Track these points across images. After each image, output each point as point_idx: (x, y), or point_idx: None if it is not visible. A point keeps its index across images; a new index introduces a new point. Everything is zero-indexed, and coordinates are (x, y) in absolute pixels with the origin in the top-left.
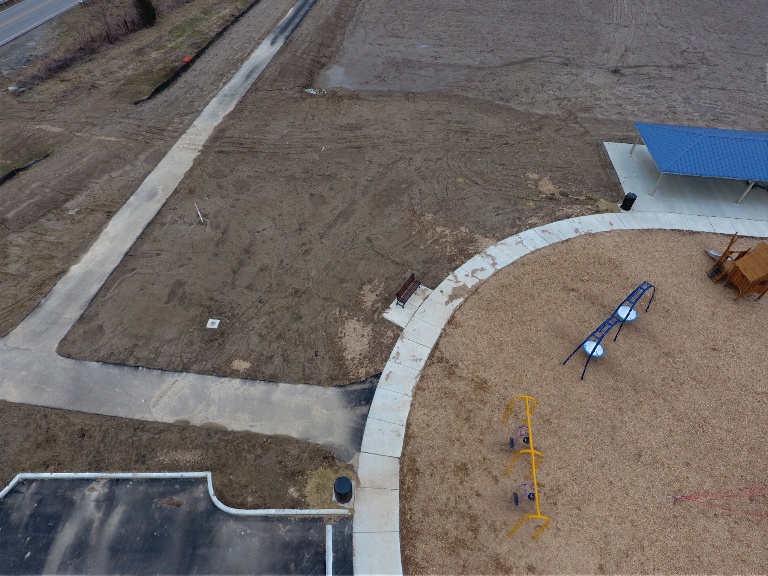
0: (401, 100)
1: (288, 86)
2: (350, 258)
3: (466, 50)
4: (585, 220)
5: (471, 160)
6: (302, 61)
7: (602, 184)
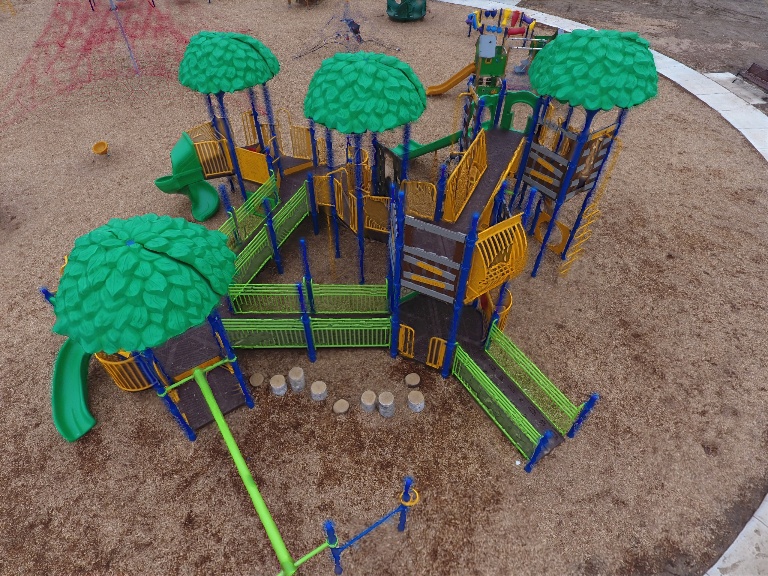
0: None
1: None
2: None
3: None
4: None
5: None
6: None
7: None
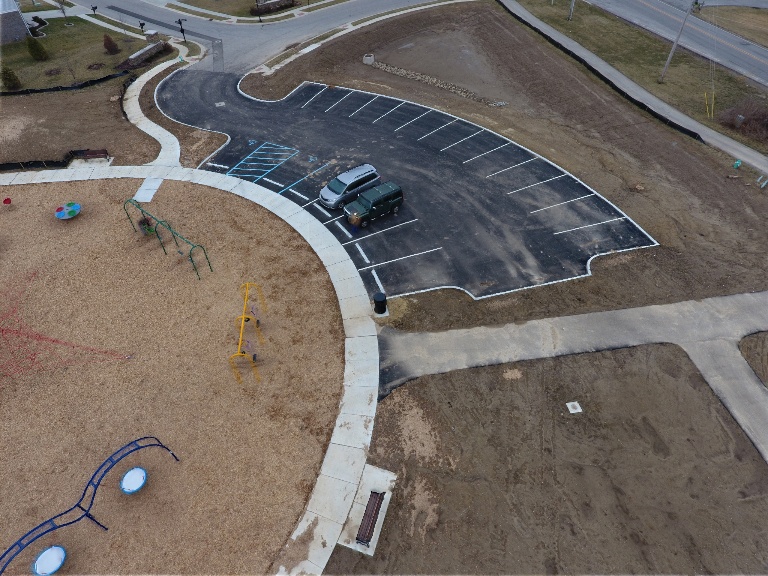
0: None
1: None
2: (480, 575)
3: None
4: None
5: None
6: None
7: None
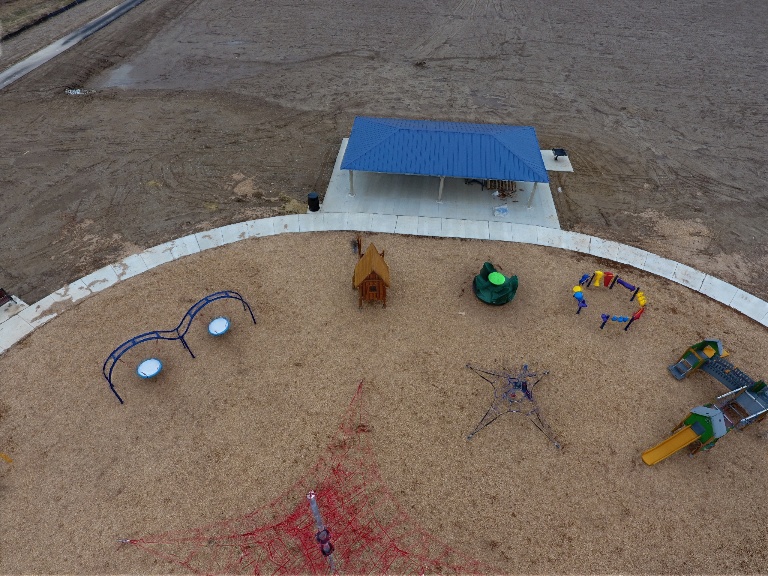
0: (154, 99)
1: (48, 87)
2: None
3: (276, 46)
4: (260, 223)
5: (181, 161)
6: (85, 61)
7: (309, 183)
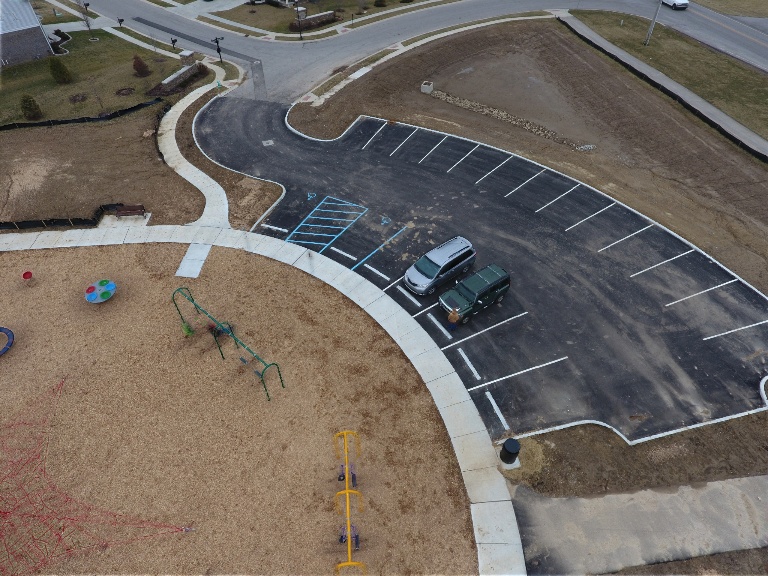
0: None
1: None
2: None
3: None
4: None
5: None
6: None
7: None
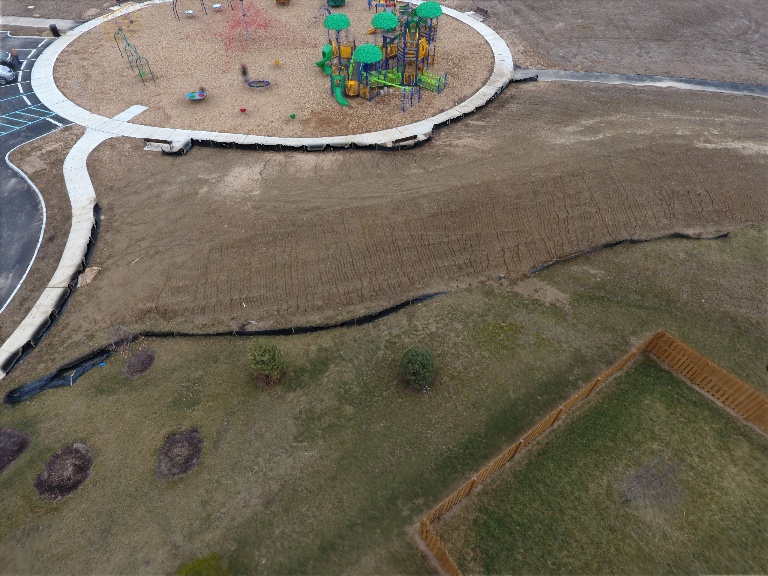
0: None
1: None
2: None
3: None
4: None
5: None
6: None
7: None
